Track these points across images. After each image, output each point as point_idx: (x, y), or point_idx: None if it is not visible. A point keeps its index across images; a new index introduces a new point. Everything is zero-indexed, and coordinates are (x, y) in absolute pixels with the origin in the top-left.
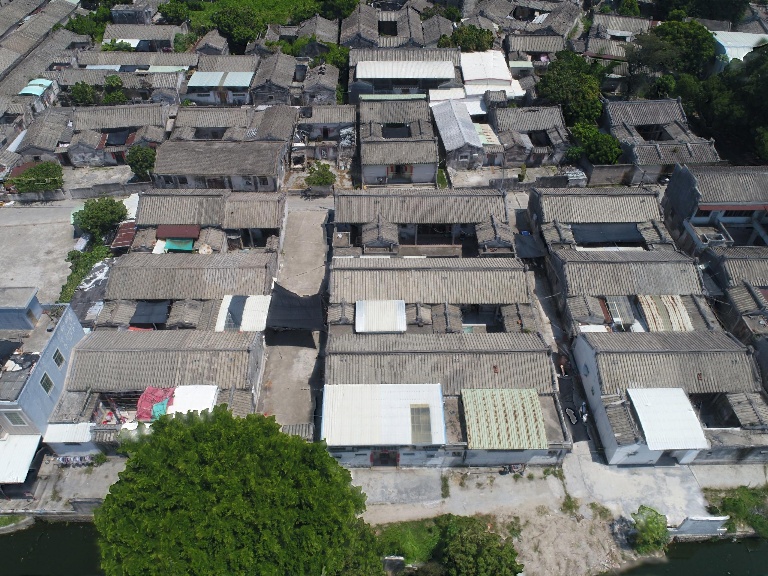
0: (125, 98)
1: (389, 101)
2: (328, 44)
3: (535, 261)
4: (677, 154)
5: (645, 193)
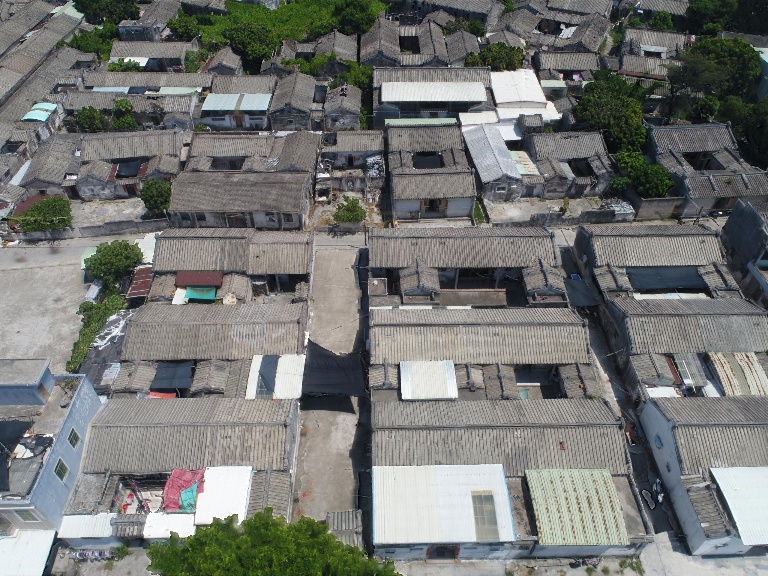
0: (135, 123)
1: (419, 127)
2: (348, 62)
3: (587, 308)
4: (732, 186)
5: (705, 233)
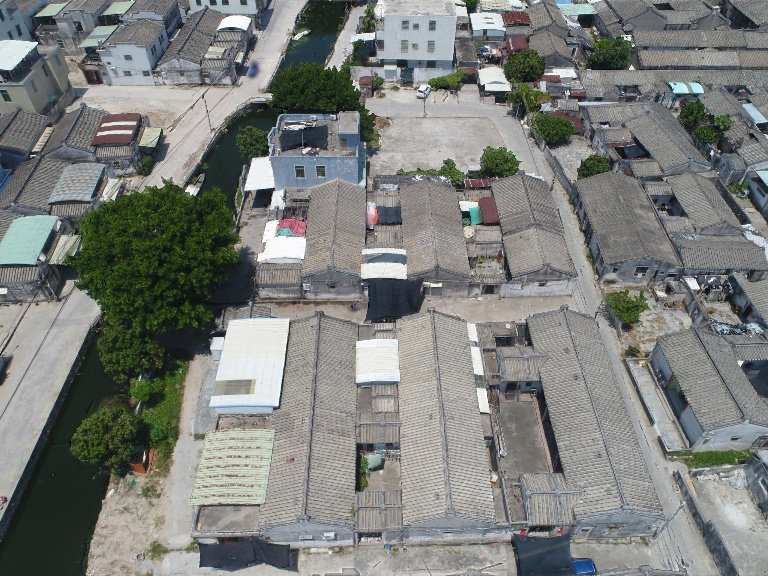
0: (711, 141)
1: None
2: None
3: None
4: None
5: None
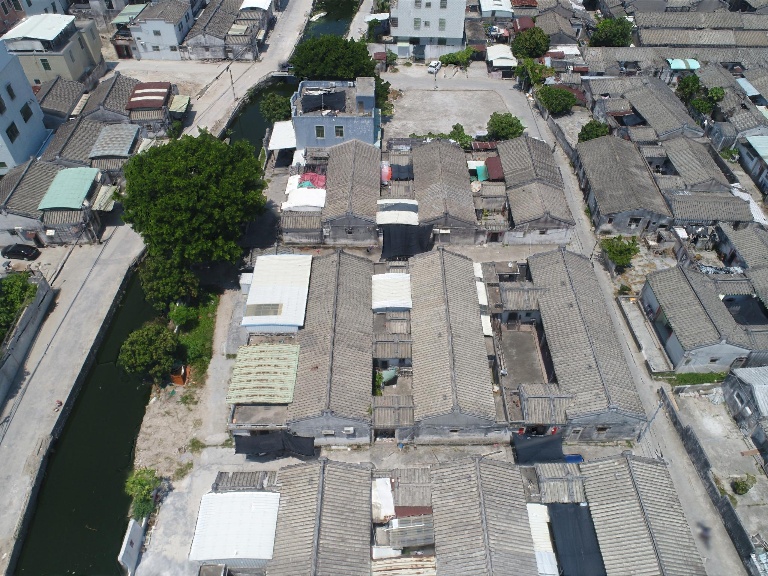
0: (705, 111)
1: None
2: None
3: None
4: None
5: None
